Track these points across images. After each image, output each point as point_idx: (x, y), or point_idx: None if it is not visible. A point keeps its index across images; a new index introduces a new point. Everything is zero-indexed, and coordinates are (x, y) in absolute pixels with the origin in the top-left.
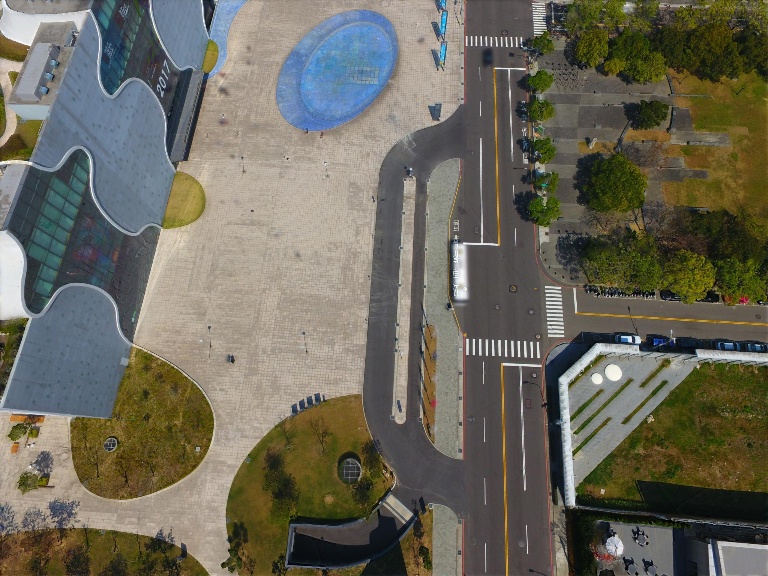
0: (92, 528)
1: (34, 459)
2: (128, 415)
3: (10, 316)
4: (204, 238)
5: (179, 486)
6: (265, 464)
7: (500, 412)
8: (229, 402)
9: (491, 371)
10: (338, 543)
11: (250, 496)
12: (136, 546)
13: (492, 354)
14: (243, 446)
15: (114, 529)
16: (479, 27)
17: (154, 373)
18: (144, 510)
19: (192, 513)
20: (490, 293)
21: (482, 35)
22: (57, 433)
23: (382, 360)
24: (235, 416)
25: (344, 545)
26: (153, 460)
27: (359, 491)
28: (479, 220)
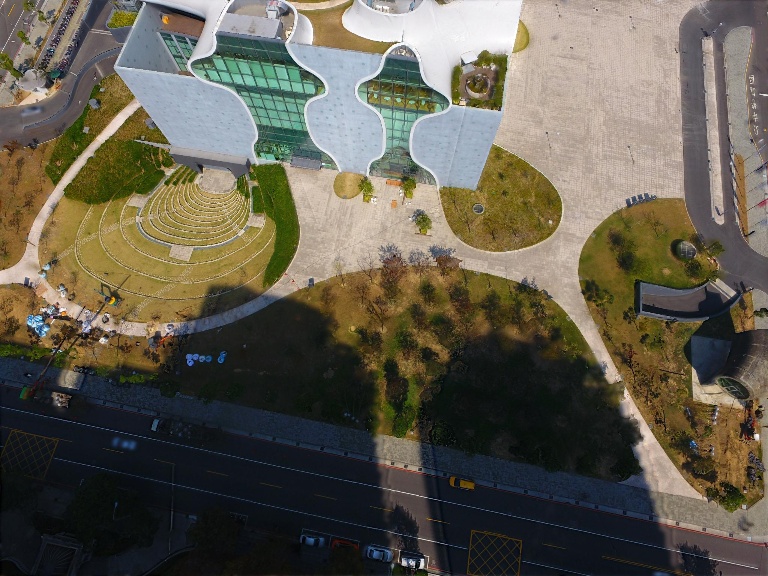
0: (468, 269)
1: (411, 214)
2: (489, 189)
3: (498, 50)
4: (532, 64)
5: (537, 248)
6: (608, 240)
7: None
8: (572, 190)
9: None
10: (669, 309)
11: (599, 262)
12: (506, 287)
13: None
14: (588, 224)
15: (487, 272)
16: None
17: (505, 161)
18: (510, 262)
19: (550, 269)
20: None
21: None
22: (428, 197)
23: (698, 175)
24: (579, 201)
25: (675, 311)
26: (514, 225)
27: (690, 269)
28: None
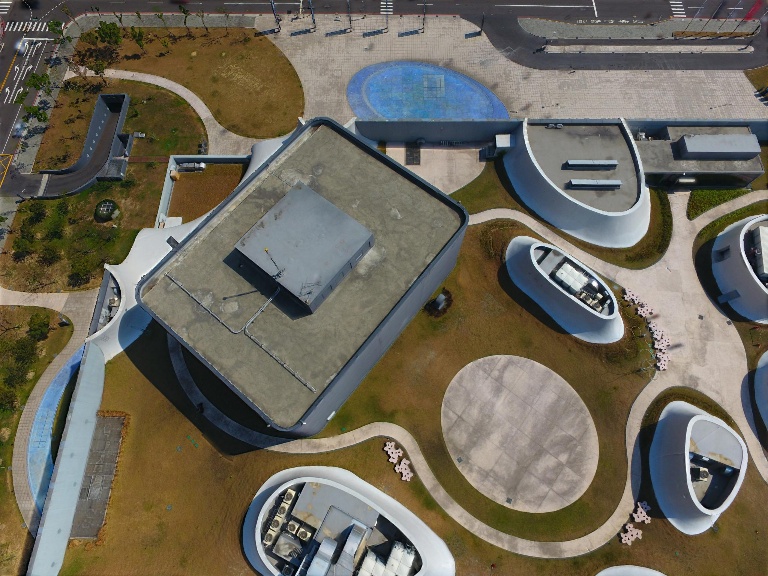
0: None
1: None
2: None
3: None
4: None
5: None
6: None
7: (719, 0)
8: None
9: (693, 4)
10: None
11: None
12: None
13: (680, 3)
14: None
15: None
16: (369, 4)
17: None
18: None
19: None
20: (634, 3)
21: (379, 2)
22: None
23: (712, 60)
24: None
25: None
26: None
27: None
28: (574, 8)
